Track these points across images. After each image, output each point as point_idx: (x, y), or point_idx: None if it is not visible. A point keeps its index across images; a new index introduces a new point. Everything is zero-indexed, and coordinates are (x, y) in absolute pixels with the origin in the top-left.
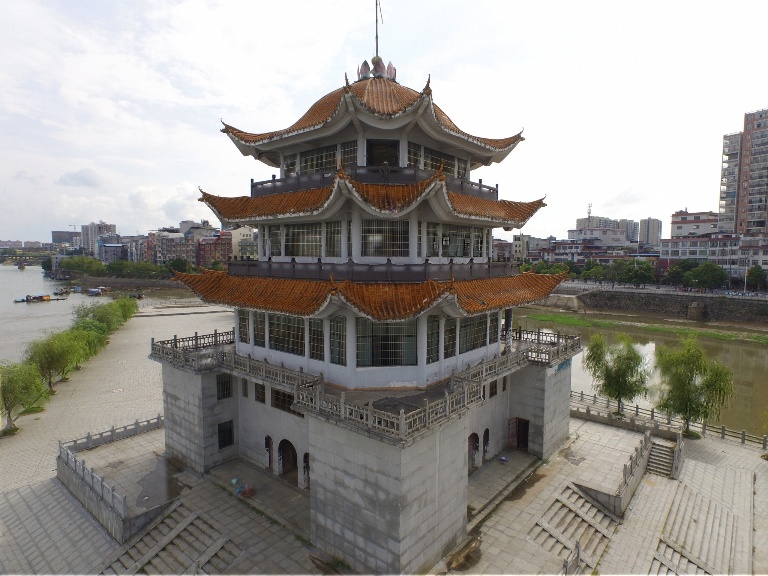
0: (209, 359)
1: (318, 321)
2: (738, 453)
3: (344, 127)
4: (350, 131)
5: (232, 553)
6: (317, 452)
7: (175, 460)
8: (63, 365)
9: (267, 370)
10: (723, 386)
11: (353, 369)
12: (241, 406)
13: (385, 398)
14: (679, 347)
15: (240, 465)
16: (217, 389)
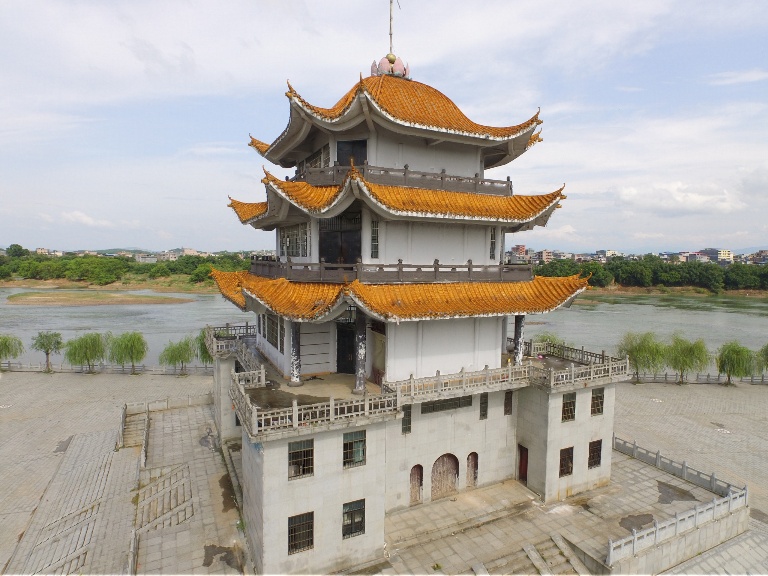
0: None
1: None
2: None
3: None
4: None
5: None
6: None
7: None
8: (641, 361)
9: None
10: None
11: None
12: None
13: None
14: None
15: None
16: None
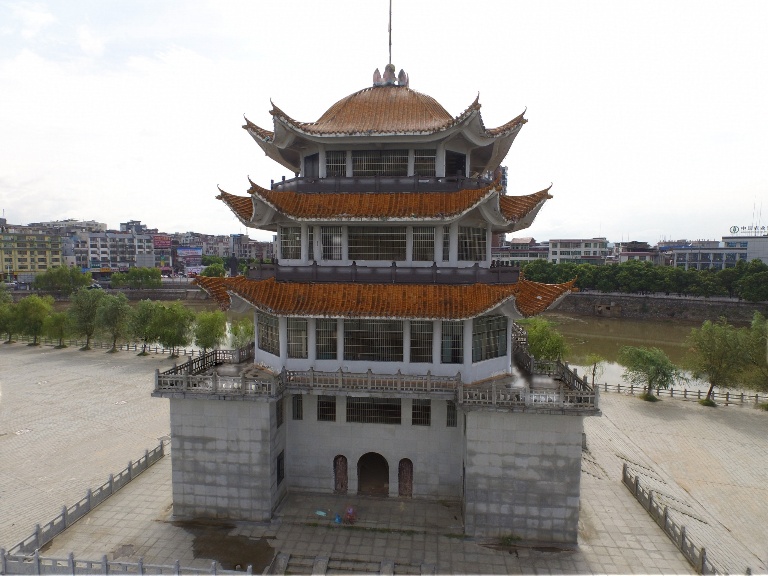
0: (278, 381)
1: (425, 324)
2: None
3: (444, 137)
4: (437, 140)
5: (411, 573)
6: (479, 445)
7: (204, 519)
8: None
9: (374, 381)
10: (559, 350)
11: (471, 365)
12: (289, 432)
13: (507, 386)
14: (526, 326)
15: (299, 498)
16: (276, 416)
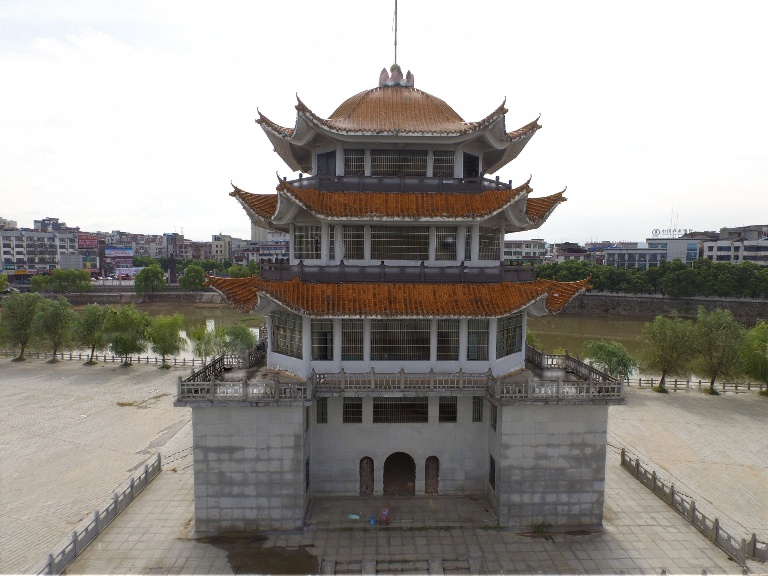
0: (311, 385)
1: (452, 323)
2: None
3: (467, 139)
4: None
5: (460, 567)
6: (514, 438)
7: (231, 533)
8: None
9: (407, 380)
10: None
11: (495, 362)
12: (314, 436)
13: None
14: None
15: (326, 503)
16: None
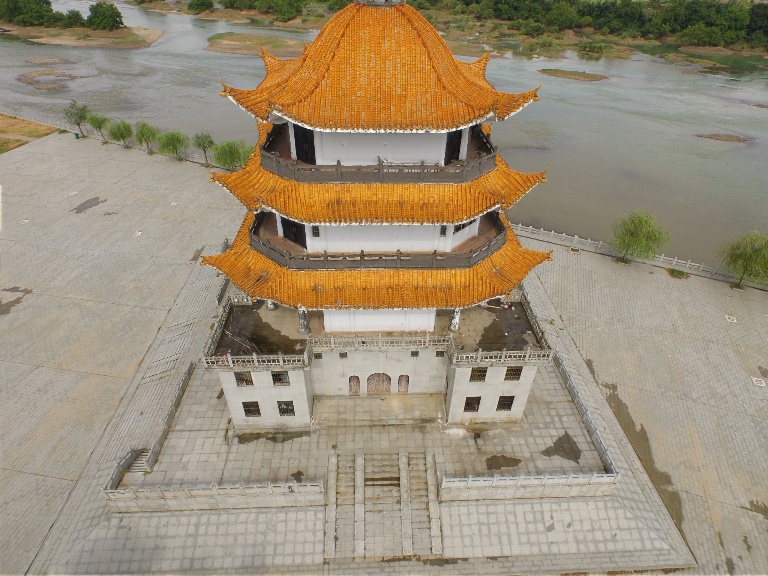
0: None
1: None
2: None
3: None
4: None
5: None
6: None
7: None
8: None
9: None
10: None
11: None
12: None
13: None
14: None
15: None
16: None
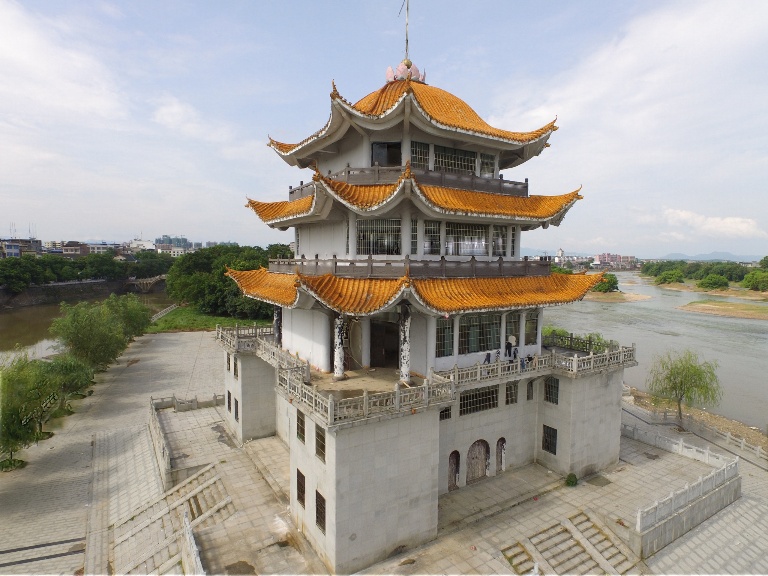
0: (548, 340)
1: None
2: (47, 445)
3: None
4: None
5: None
6: None
7: None
8: None
9: None
10: None
11: None
12: None
13: None
14: None
15: None
16: None
